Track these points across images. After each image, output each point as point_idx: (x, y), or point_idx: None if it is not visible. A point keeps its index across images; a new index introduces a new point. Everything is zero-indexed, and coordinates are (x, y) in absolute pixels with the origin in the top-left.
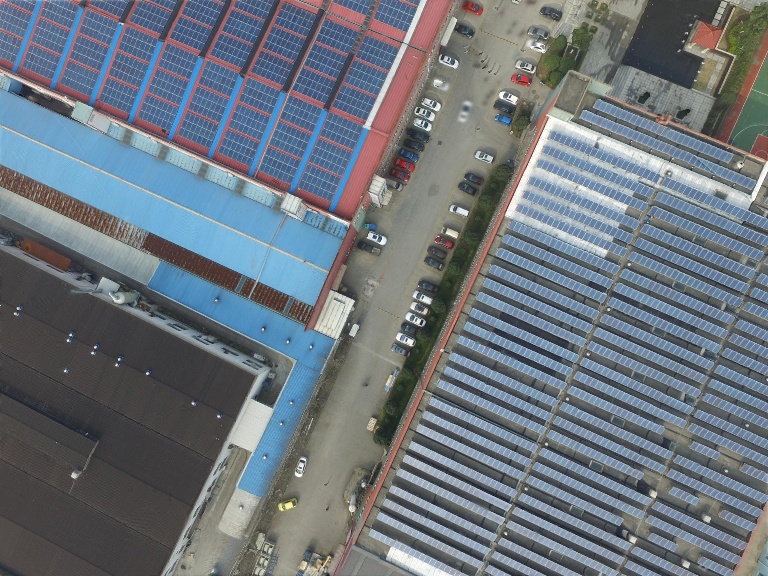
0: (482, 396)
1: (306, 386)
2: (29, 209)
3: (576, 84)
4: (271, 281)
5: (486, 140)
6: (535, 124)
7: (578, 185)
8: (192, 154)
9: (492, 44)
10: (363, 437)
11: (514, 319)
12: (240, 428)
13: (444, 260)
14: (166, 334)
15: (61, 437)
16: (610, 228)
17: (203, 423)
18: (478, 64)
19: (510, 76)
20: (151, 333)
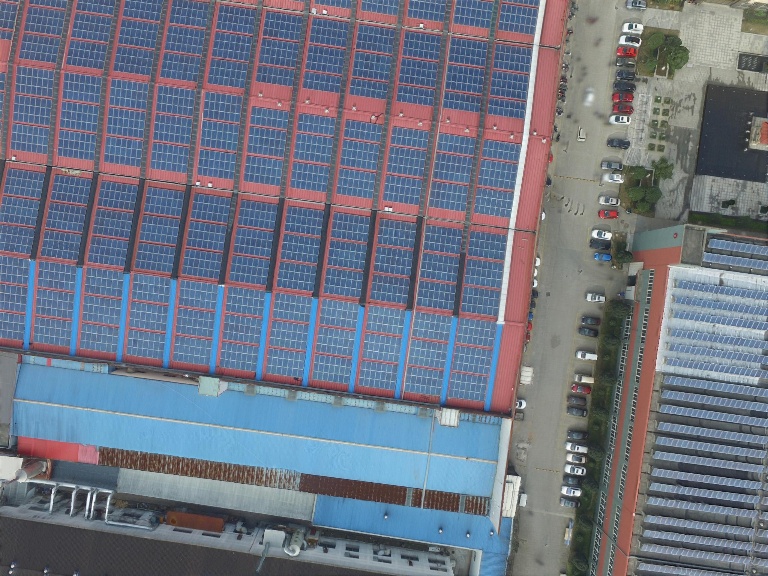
0: (683, 545)
1: (497, 571)
2: (161, 480)
3: (694, 235)
4: (437, 485)
5: (591, 280)
6: (638, 258)
7: (715, 324)
8: None
9: (570, 186)
10: None
11: (692, 465)
12: None
13: (585, 405)
14: (355, 573)
15: None
16: (757, 357)
17: None
18: (563, 209)
19: (596, 213)
20: None
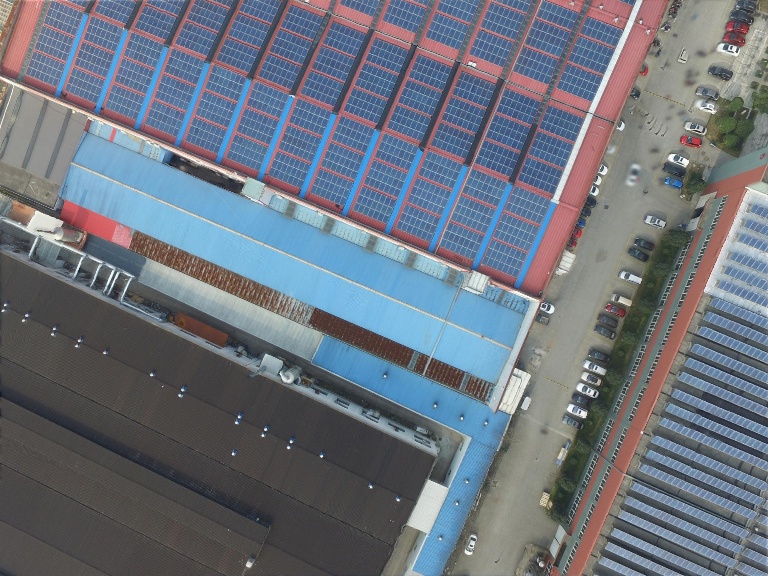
0: (686, 480)
1: (481, 463)
2: (181, 282)
3: None
4: (445, 356)
5: (655, 204)
6: (712, 189)
7: None
8: (367, 229)
9: (658, 105)
10: (534, 512)
11: (718, 399)
12: (415, 509)
13: (615, 328)
14: (342, 416)
15: (233, 524)
16: None
17: (376, 504)
18: (644, 125)
19: (679, 138)
20: (327, 415)
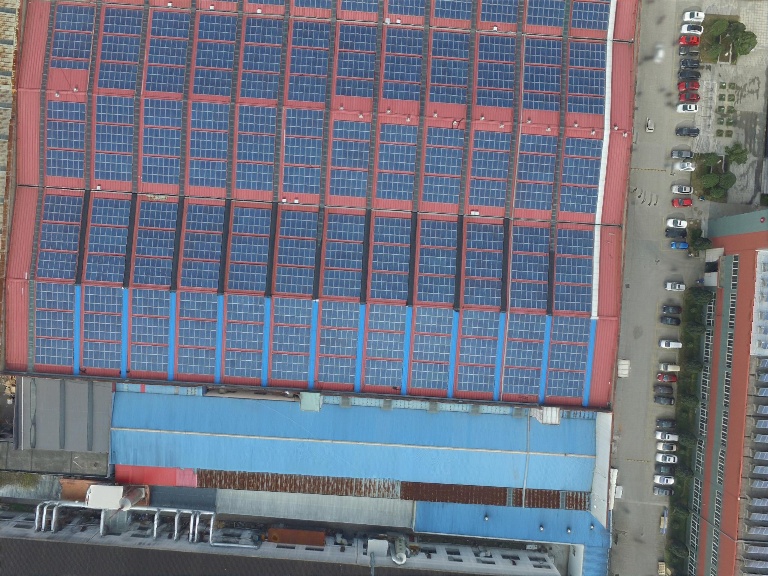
0: None
1: (599, 564)
2: (258, 498)
3: None
4: (536, 483)
5: (669, 269)
6: (717, 244)
7: None
8: None
9: (642, 178)
10: None
11: None
12: None
13: (672, 394)
14: None
15: None
16: None
17: None
18: (636, 200)
19: (670, 202)
20: None
